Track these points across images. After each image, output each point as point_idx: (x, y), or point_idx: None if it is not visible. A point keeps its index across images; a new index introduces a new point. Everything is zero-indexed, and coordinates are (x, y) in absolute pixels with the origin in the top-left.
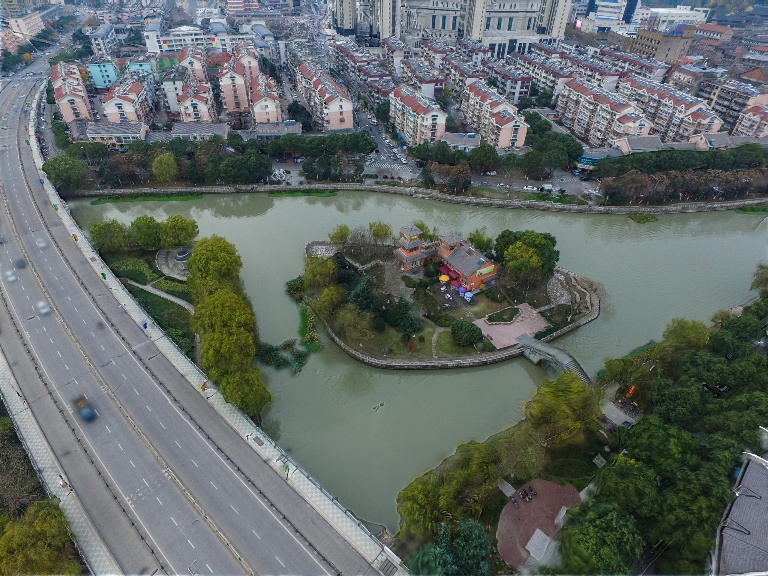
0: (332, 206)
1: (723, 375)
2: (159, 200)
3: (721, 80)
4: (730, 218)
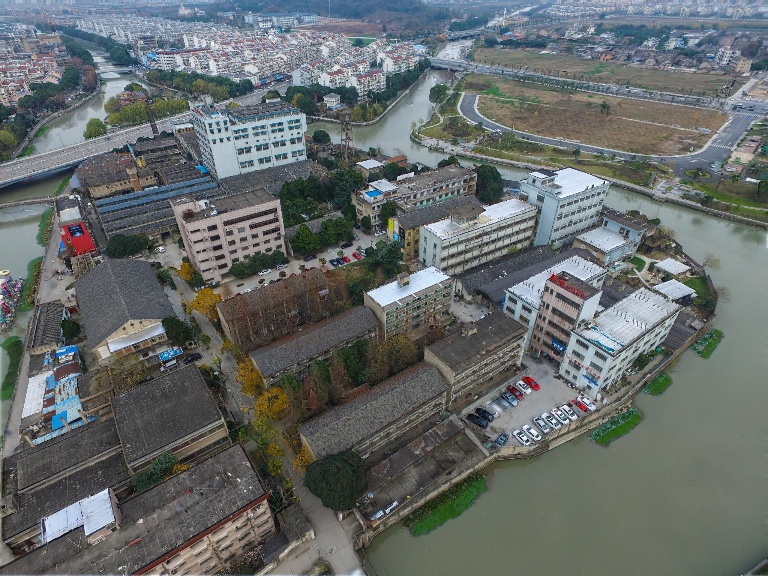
0: (36, 144)
1: (193, 78)
2: (29, 154)
3: (2, 55)
4: (102, 89)
